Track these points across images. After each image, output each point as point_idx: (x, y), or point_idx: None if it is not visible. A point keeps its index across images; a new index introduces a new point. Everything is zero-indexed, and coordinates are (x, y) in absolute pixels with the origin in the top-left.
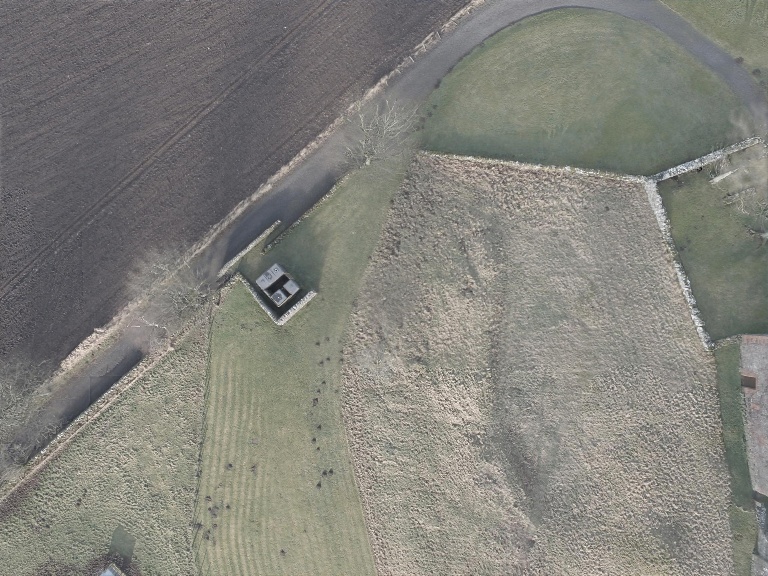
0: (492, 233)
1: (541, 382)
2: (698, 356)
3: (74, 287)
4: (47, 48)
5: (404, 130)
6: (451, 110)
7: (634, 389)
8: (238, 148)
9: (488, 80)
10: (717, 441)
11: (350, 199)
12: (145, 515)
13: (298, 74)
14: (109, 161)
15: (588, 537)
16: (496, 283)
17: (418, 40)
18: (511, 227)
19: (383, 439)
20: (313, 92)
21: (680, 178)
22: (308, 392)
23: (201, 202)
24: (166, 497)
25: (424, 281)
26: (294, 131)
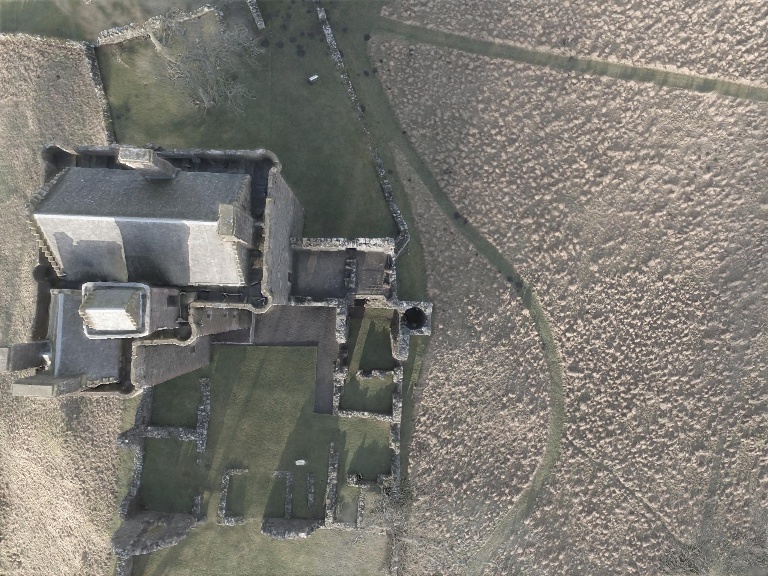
0: None
1: None
2: None
3: None
4: None
5: None
6: None
7: None
8: None
9: None
10: None
11: None
12: None
13: None
14: None
15: (23, 417)
16: None
17: None
18: None
19: None
20: None
21: (125, 45)
22: None
23: None
24: None
25: None
26: None
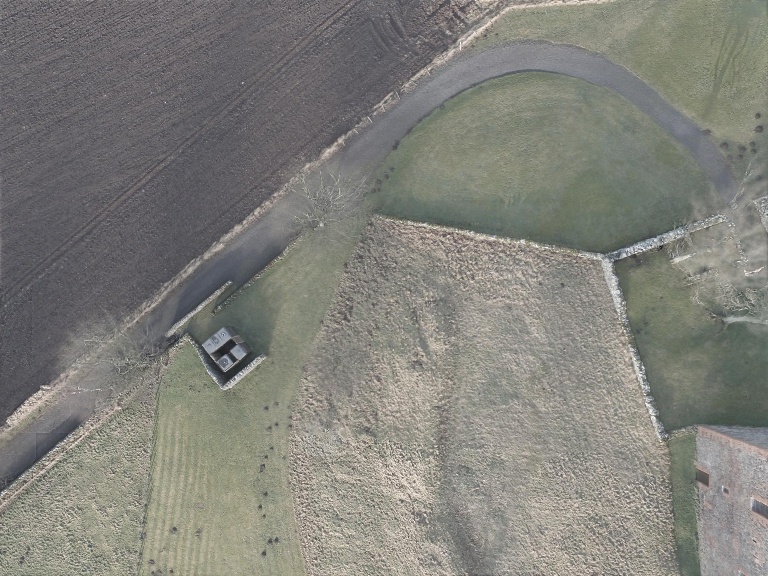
0: (444, 304)
1: (490, 462)
2: (651, 446)
3: (23, 342)
4: (4, 98)
5: (354, 198)
6: (408, 174)
7: (584, 478)
8: (192, 205)
9: (446, 144)
10: (668, 538)
11: (303, 261)
12: (88, 575)
13: (254, 131)
14: (62, 214)
15: None
16: (447, 357)
17: (377, 100)
18: (464, 299)
19: (330, 509)
20: (269, 150)
21: (639, 257)
22: (255, 457)
23: (153, 259)
24: (109, 558)
25: (375, 349)
26: (249, 189)
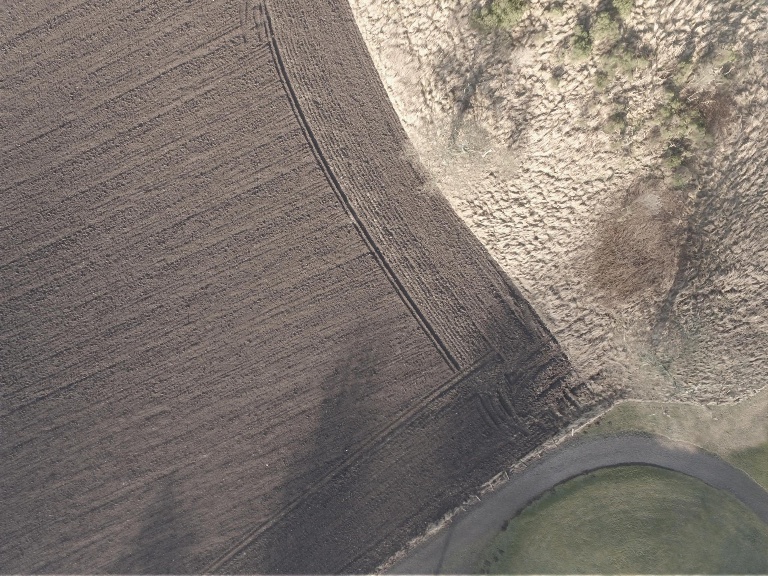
0: None
1: None
2: None
3: None
4: (102, 452)
5: None
6: (519, 562)
7: None
8: (294, 571)
9: (559, 535)
10: None
11: None
12: None
13: (359, 500)
14: (162, 574)
15: None
16: None
17: (485, 478)
18: None
19: None
20: (374, 520)
21: None
22: None
23: None
24: None
25: None
26: (353, 558)
